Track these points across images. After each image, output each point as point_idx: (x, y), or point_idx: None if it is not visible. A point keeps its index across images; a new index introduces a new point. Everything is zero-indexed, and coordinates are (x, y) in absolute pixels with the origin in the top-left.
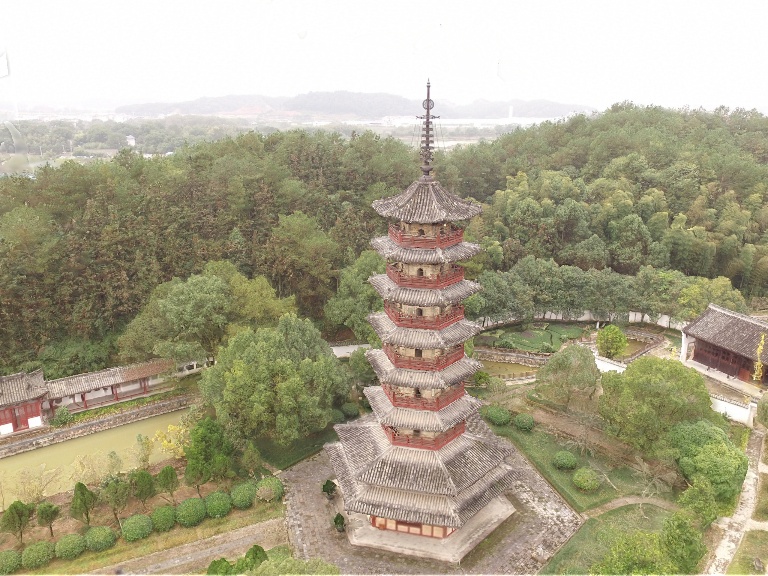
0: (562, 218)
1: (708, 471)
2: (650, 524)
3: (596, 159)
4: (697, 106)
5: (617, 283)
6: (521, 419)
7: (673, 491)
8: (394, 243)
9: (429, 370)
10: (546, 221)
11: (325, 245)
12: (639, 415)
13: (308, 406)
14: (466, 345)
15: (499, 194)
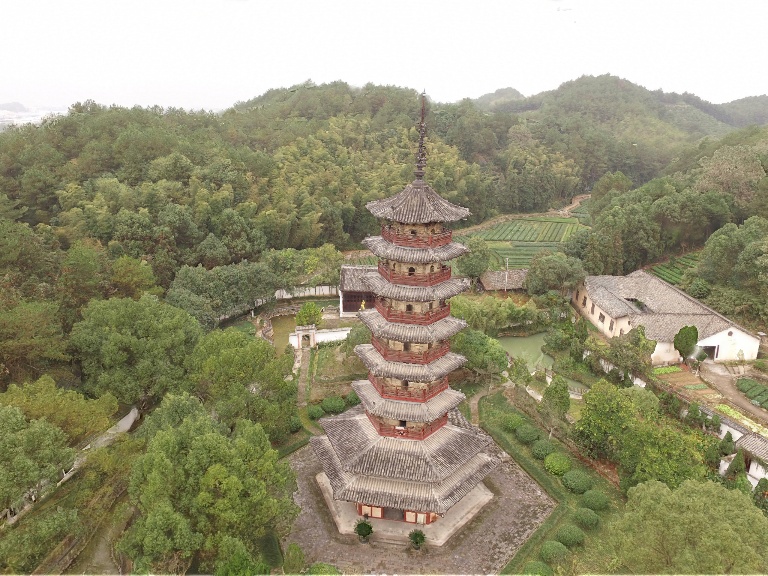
0: (175, 224)
1: (500, 357)
2: (500, 406)
3: (133, 162)
4: (145, 106)
5: (260, 271)
6: None
7: (477, 384)
8: (406, 249)
9: (443, 355)
10: (163, 230)
11: (44, 312)
12: (462, 340)
13: (291, 473)
14: None
15: (73, 212)
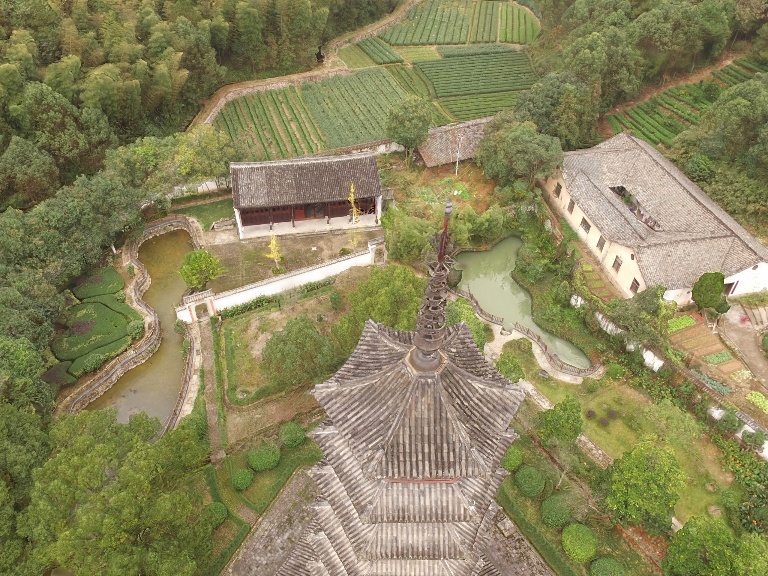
0: None
1: None
2: None
3: None
4: None
5: (109, 190)
6: (294, 437)
7: None
8: (406, 483)
9: None
10: None
11: None
12: None
13: None
14: (188, 433)
15: None
